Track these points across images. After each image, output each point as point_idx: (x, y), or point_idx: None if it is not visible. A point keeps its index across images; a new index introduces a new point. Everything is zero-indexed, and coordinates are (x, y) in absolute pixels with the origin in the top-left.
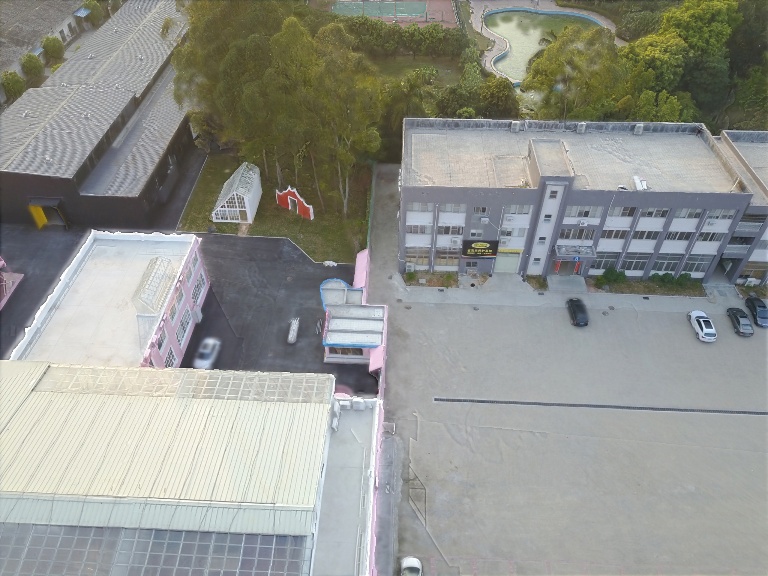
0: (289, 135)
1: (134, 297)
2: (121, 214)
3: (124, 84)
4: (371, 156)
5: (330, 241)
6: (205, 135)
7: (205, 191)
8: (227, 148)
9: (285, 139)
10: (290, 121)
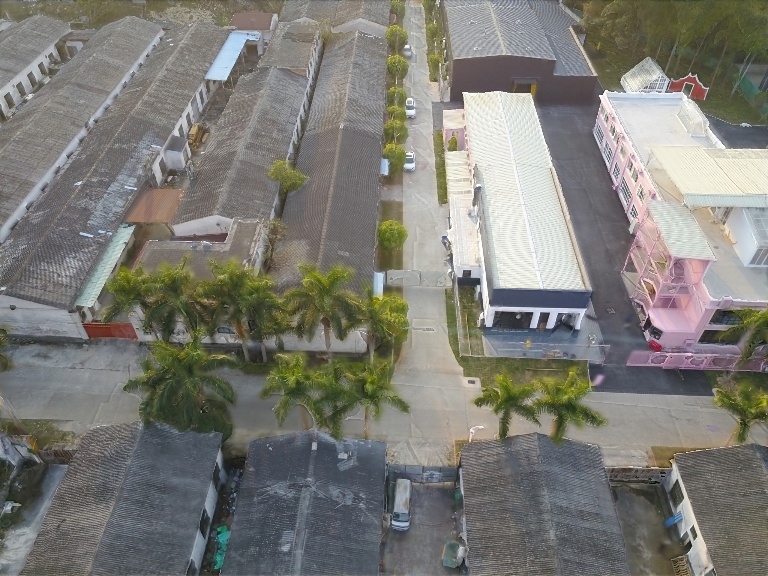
0: (750, 19)
1: (697, 121)
2: (576, 92)
3: (513, 5)
4: (740, 53)
5: (731, 113)
6: (622, 35)
7: (606, 83)
8: (600, 54)
9: (703, 33)
10: (752, 8)
